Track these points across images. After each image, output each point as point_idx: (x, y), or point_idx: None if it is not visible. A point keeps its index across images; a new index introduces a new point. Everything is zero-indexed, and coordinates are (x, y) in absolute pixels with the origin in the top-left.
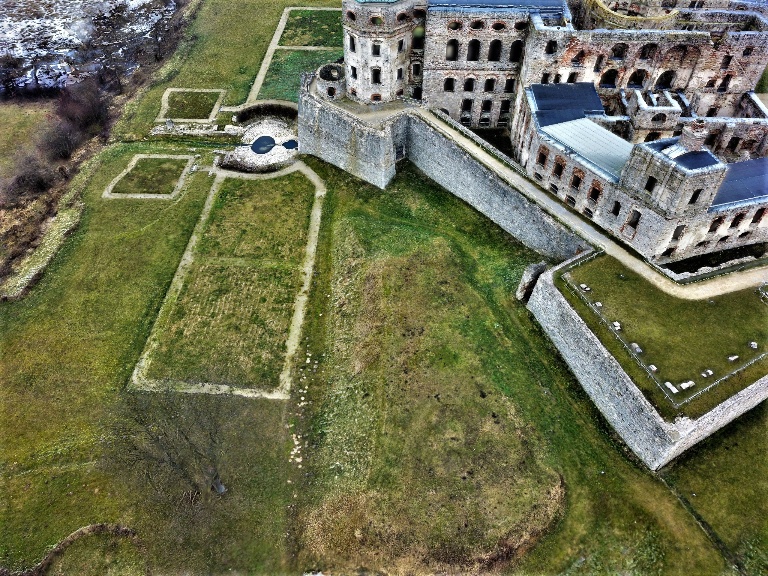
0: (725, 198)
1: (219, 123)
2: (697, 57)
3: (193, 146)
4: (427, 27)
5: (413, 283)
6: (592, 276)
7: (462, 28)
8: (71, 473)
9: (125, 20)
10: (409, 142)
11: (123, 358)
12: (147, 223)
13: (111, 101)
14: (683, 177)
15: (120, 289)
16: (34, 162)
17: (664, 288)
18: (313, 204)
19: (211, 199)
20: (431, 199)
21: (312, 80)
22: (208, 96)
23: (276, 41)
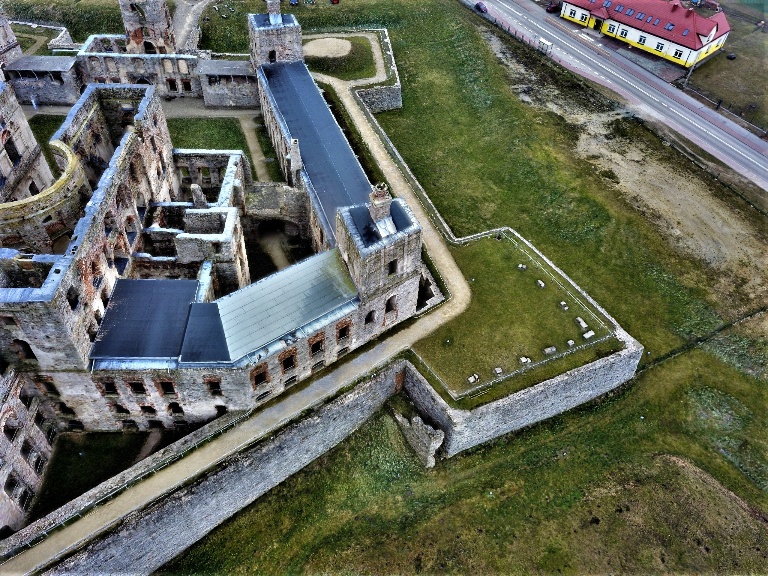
0: None
1: None
2: (140, 162)
3: None
4: None
5: None
6: (451, 369)
7: None
8: None
9: None
10: None
11: None
12: None
13: None
14: (419, 233)
15: None
16: None
17: (458, 311)
18: None
19: None
20: None
21: None
22: None
23: None
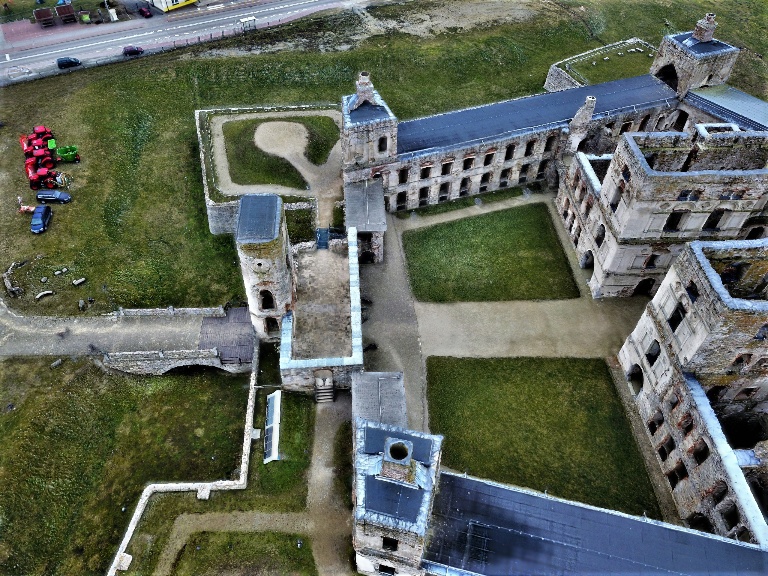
0: (637, 78)
1: None
2: None
3: None
4: None
5: None
6: None
7: None
8: None
9: None
10: None
11: None
12: None
13: None
14: None
15: None
16: None
17: None
18: None
19: None
20: None
21: None
22: None
23: None
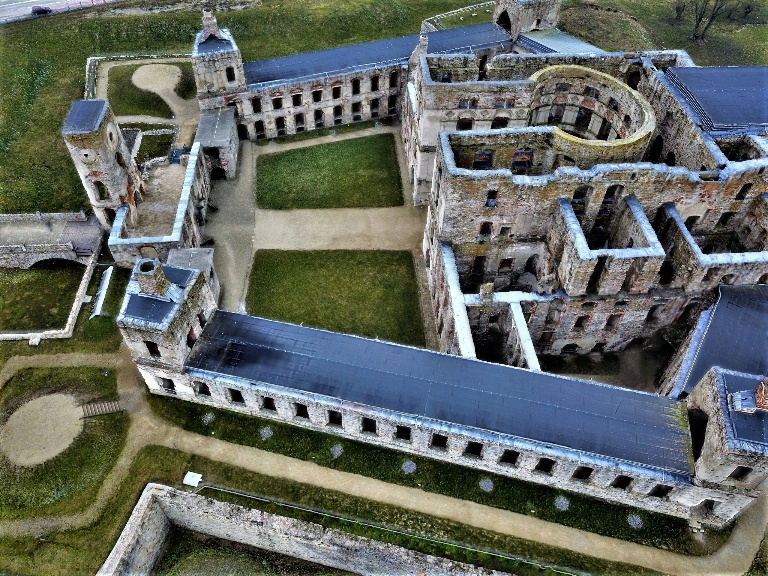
0: (480, 25)
1: None
2: None
3: None
4: None
5: None
6: None
7: None
8: (765, 41)
9: None
10: None
11: None
12: None
13: None
14: None
15: None
16: None
17: None
18: None
19: None
20: None
21: None
22: None
23: None
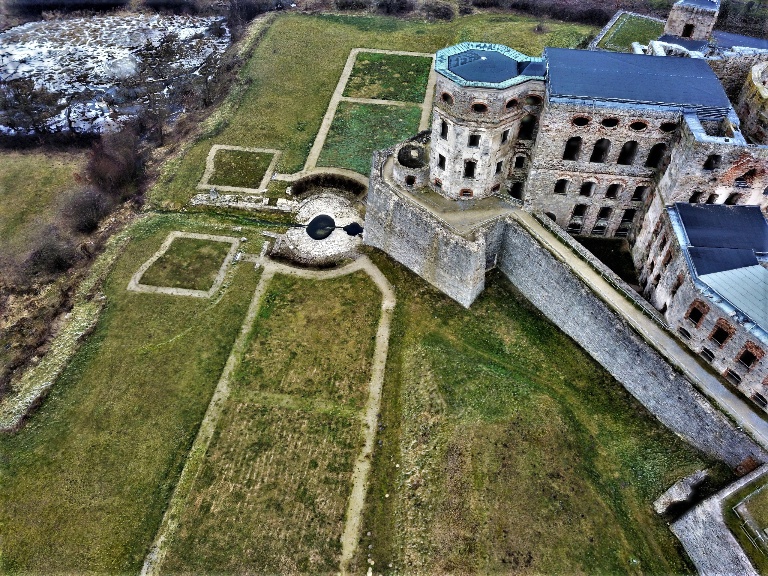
0: None
1: (271, 195)
2: None
3: (239, 223)
4: (545, 121)
5: (513, 471)
6: None
7: (591, 125)
8: None
9: (174, 52)
10: (503, 251)
11: (131, 545)
12: (177, 332)
13: (150, 155)
14: None
15: (136, 431)
16: (55, 232)
17: None
18: (379, 320)
19: (256, 303)
20: (530, 332)
21: (387, 160)
22: (260, 158)
23: (340, 91)
